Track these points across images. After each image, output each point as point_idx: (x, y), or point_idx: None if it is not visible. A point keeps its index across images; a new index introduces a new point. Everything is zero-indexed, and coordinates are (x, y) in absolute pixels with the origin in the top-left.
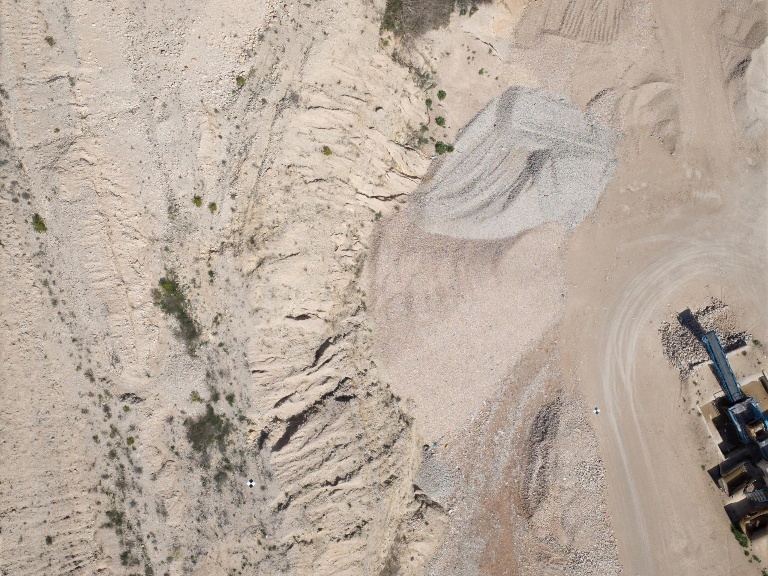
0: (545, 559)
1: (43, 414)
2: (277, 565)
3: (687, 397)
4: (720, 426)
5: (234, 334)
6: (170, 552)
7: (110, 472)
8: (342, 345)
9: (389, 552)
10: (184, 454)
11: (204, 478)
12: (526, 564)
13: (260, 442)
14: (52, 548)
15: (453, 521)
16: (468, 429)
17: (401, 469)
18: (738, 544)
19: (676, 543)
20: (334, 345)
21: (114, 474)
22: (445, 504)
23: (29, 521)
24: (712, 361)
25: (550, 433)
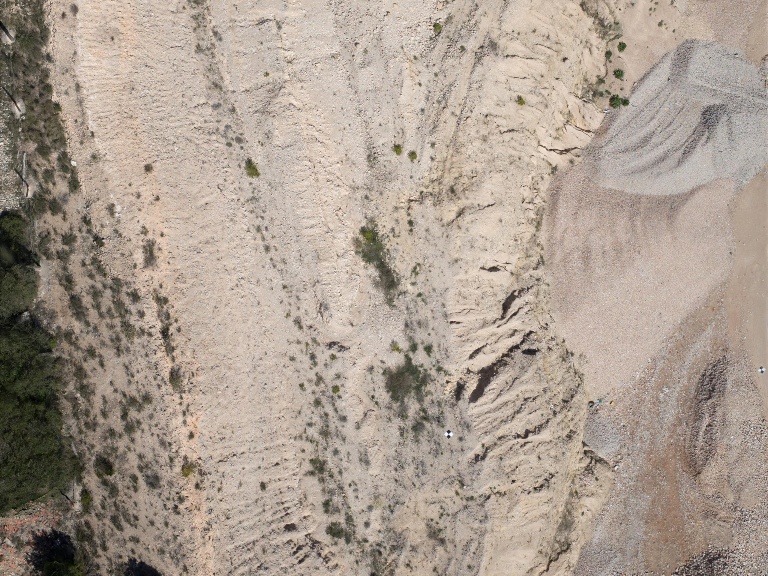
0: (712, 516)
1: (257, 360)
2: (475, 515)
3: None
4: None
5: (433, 284)
6: (371, 501)
7: (314, 420)
8: (526, 298)
9: (564, 506)
10: (383, 404)
11: (402, 428)
12: (692, 521)
13: (457, 393)
14: (265, 494)
15: (619, 477)
16: (633, 386)
17: (578, 424)
18: None
19: None
20: (520, 298)
21: (318, 422)
22: (611, 460)
23: (247, 466)
24: None
25: (718, 391)
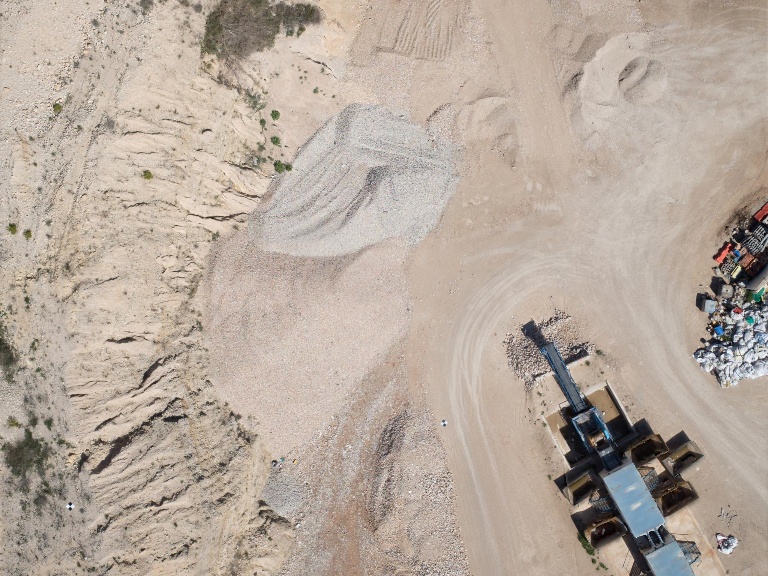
0: (390, 571)
1: None
2: None
3: (532, 408)
4: (568, 436)
5: (51, 359)
6: None
7: None
8: (172, 366)
9: (228, 569)
10: (3, 479)
11: (24, 502)
12: None
13: (80, 465)
14: None
15: (300, 535)
16: (316, 444)
17: (238, 486)
18: (585, 552)
19: (525, 552)
20: (163, 366)
21: None
22: (292, 519)
23: None
24: (554, 372)
25: (395, 446)
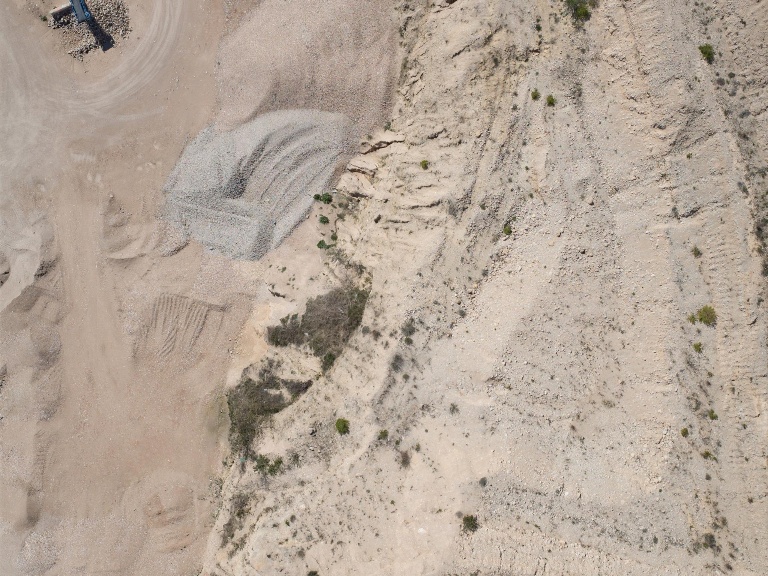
0: None
1: None
2: None
3: None
4: None
5: None
6: None
7: None
8: None
9: None
10: None
11: None
12: None
13: None
14: None
15: None
16: None
17: None
18: None
19: None
20: None
21: None
22: None
23: None
24: None
25: None
